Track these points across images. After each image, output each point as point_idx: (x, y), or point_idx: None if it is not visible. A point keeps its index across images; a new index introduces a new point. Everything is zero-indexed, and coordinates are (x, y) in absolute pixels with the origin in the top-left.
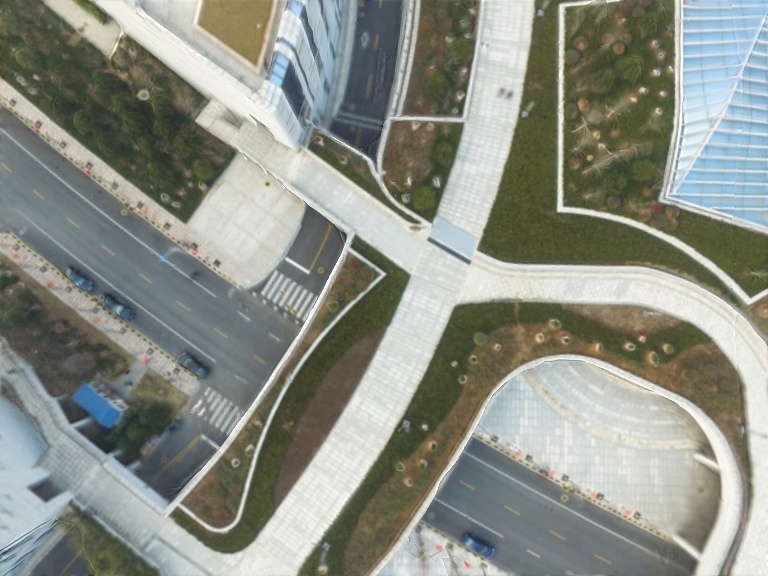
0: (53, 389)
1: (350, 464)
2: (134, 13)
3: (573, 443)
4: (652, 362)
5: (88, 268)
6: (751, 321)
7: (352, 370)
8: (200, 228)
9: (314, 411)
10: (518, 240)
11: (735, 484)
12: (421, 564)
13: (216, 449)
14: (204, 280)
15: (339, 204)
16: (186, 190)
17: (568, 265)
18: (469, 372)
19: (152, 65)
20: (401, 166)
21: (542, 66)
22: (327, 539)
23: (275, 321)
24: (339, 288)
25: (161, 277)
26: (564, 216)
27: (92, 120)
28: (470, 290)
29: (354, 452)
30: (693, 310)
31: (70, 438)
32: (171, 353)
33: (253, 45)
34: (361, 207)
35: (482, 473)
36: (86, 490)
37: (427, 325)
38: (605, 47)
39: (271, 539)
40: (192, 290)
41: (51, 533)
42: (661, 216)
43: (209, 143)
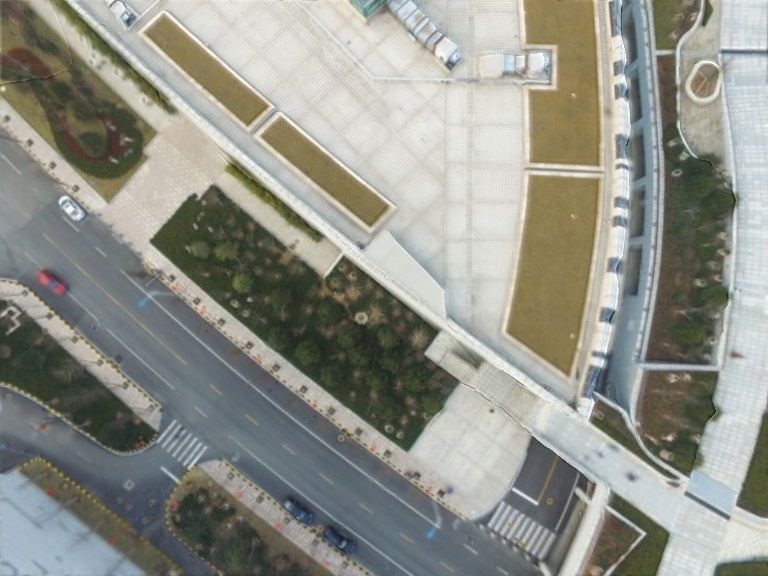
0: None
1: None
2: None
3: None
4: None
5: (305, 497)
6: None
7: None
8: (422, 456)
9: None
10: None
11: None
12: None
13: None
14: (427, 511)
15: (591, 456)
16: (409, 418)
17: None
18: None
19: (374, 291)
20: (657, 418)
21: None
22: None
23: (503, 554)
24: (599, 550)
25: (382, 507)
26: None
27: (317, 353)
28: (730, 547)
29: None
30: None
31: None
32: None
33: (565, 354)
34: (614, 459)
35: None
36: None
37: None
38: None
39: None
40: (415, 521)
41: None
42: None
43: (437, 375)
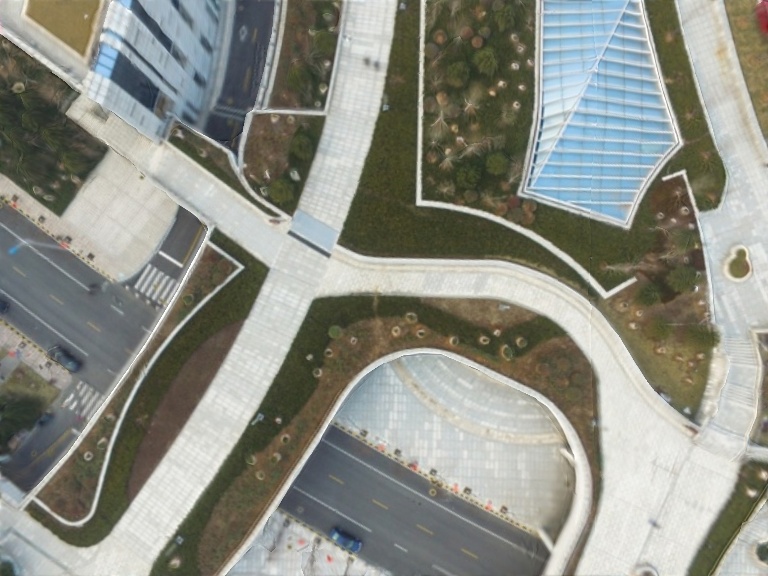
0: None
1: (204, 457)
2: None
3: (442, 437)
4: (503, 356)
5: None
6: (608, 315)
7: (208, 363)
8: (74, 221)
9: (168, 404)
10: (378, 233)
11: (585, 478)
12: (289, 558)
13: None
14: (78, 273)
15: (200, 197)
16: (60, 183)
17: (427, 259)
18: (325, 365)
19: (25, 57)
20: (261, 159)
21: (403, 59)
22: (181, 533)
23: (148, 315)
24: (196, 281)
25: (35, 270)
26: (424, 210)
27: None
28: (329, 283)
29: (208, 445)
30: (550, 304)
31: None
32: (44, 347)
33: (81, 35)
34: (222, 200)
35: (351, 467)
36: None
37: (285, 318)
38: (457, 40)
39: (126, 533)
40: (66, 284)
41: None
42: (518, 210)
43: (80, 136)
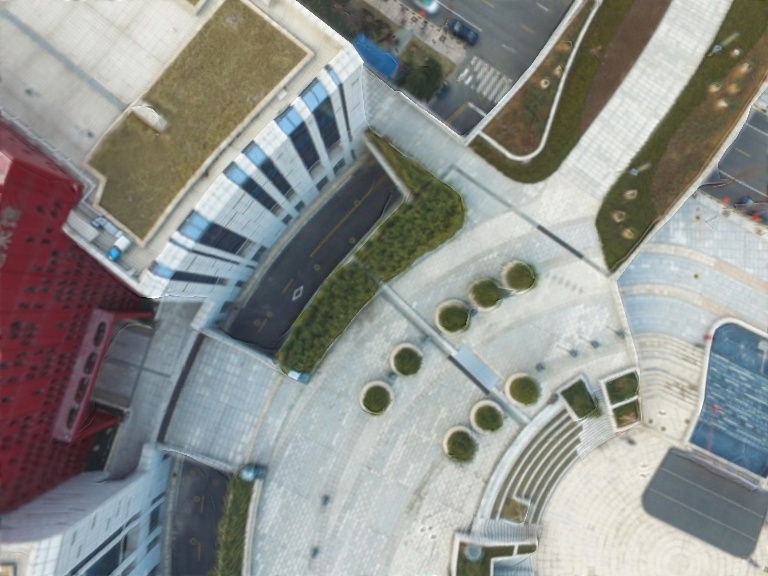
0: None
1: (659, 90)
2: None
3: None
4: None
5: None
6: None
7: None
8: None
9: (623, 35)
10: None
11: None
12: (697, 229)
13: None
14: None
15: None
16: None
17: None
18: None
19: None
20: None
21: None
22: (634, 165)
23: None
24: None
25: None
26: None
27: None
28: None
29: (663, 78)
30: None
31: None
32: (435, 22)
33: None
34: None
35: (757, 140)
36: (380, 121)
37: None
38: None
39: (574, 169)
40: None
41: (318, 194)
42: None
43: None
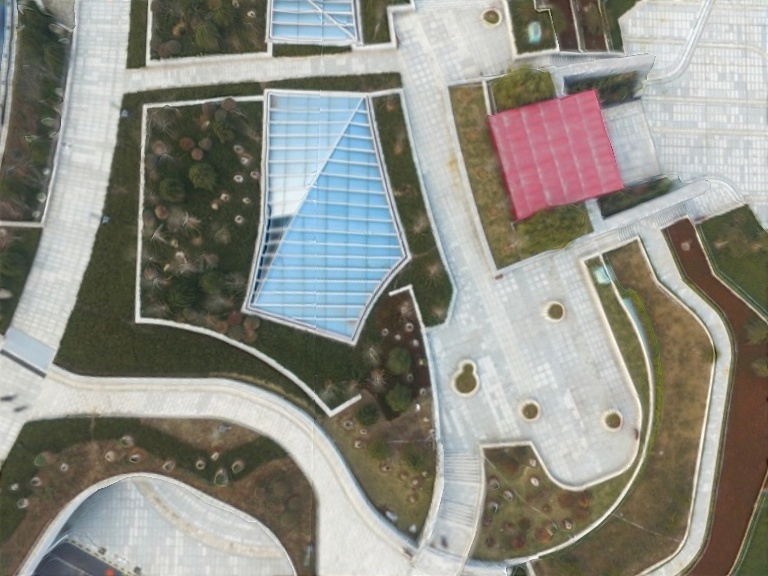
0: None
1: None
2: None
3: (184, 553)
4: None
5: None
6: (335, 433)
7: None
8: None
9: None
10: (96, 352)
11: None
12: None
13: None
14: None
15: None
16: None
17: (148, 378)
18: (33, 494)
19: None
20: None
21: (125, 169)
22: None
23: None
24: None
25: None
26: (145, 326)
27: None
28: (44, 405)
29: None
30: (273, 423)
31: None
32: None
33: None
34: None
35: None
36: None
37: None
38: (162, 158)
39: None
40: None
41: None
42: (238, 328)
43: None
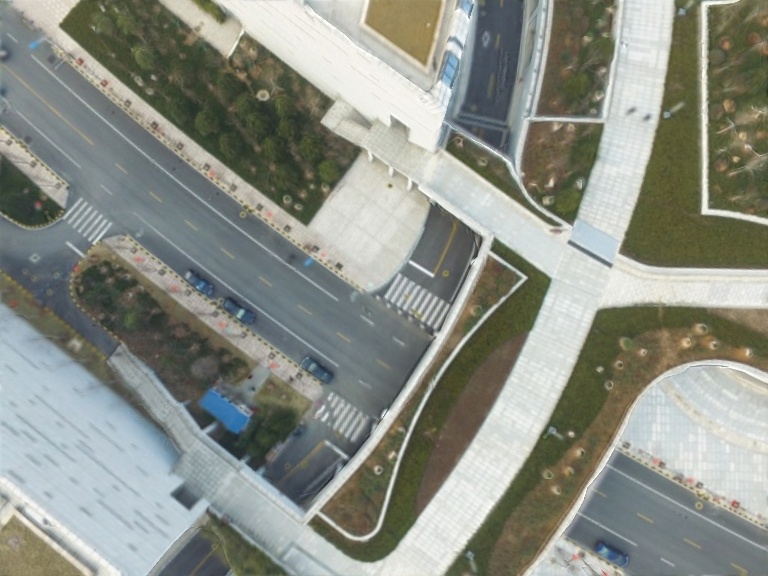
0: (178, 394)
1: (494, 471)
2: (301, 12)
3: (707, 450)
4: None
5: (207, 271)
6: None
7: (495, 376)
8: (321, 230)
9: (457, 417)
10: (661, 243)
11: None
12: (553, 573)
13: (340, 455)
14: (326, 283)
15: (477, 206)
16: (308, 192)
17: (712, 269)
18: (614, 378)
19: (274, 65)
20: (541, 168)
21: (684, 66)
22: (471, 548)
23: (399, 325)
24: (480, 292)
25: (281, 280)
26: (708, 219)
27: (215, 121)
28: (612, 294)
29: (498, 459)
30: None
31: (205, 444)
32: (293, 357)
33: (422, 44)
34: (499, 209)
35: (614, 480)
36: (221, 497)
37: (569, 330)
38: (759, 46)
39: (412, 548)
40: (313, 293)
41: None
42: None
43: (334, 144)
